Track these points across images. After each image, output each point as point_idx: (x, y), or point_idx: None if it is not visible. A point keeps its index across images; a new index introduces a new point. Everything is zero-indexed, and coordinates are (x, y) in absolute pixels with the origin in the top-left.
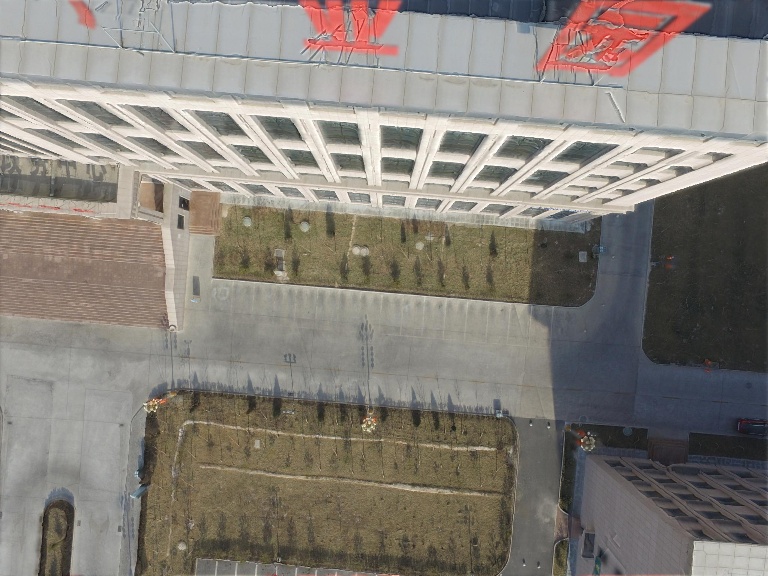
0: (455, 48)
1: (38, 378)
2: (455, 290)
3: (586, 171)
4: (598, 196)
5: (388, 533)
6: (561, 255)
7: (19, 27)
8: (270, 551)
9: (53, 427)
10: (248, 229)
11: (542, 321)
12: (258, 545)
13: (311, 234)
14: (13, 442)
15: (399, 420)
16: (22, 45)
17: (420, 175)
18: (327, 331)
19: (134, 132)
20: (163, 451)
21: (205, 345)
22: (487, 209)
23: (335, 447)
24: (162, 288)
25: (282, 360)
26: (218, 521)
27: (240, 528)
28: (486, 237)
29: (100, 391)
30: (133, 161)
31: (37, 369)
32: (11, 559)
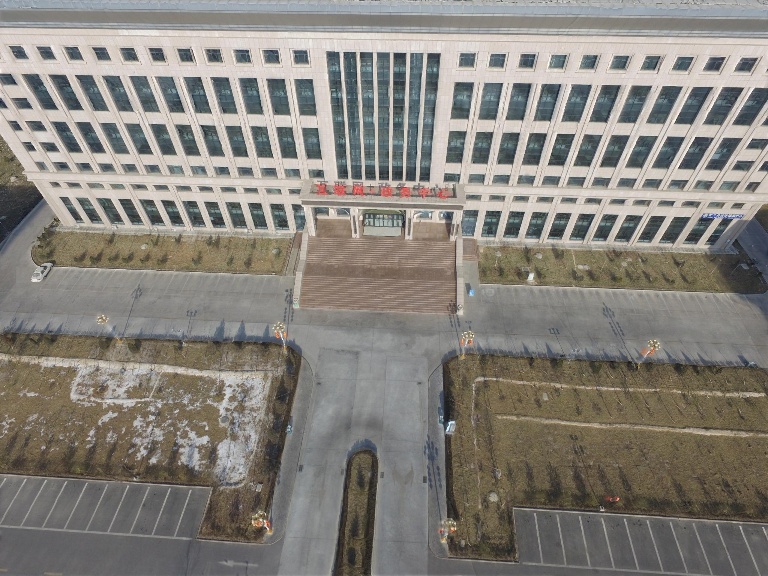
0: (730, 1)
1: (346, 349)
2: (663, 287)
3: (752, 131)
4: (753, 176)
5: (705, 479)
6: (728, 266)
7: (587, 0)
8: (589, 500)
9: (358, 386)
10: (500, 258)
11: (741, 303)
12: (573, 495)
13: (545, 260)
14: (320, 399)
15: (665, 373)
16: (590, 2)
17: (651, 161)
18: (577, 313)
19: (514, 125)
20: (460, 403)
21: (483, 324)
22: (663, 240)
23: (617, 397)
24: (451, 281)
25: (548, 332)
26: (524, 471)
27: (549, 478)
28: (669, 258)
29: (399, 357)
30: (468, 178)
31: (346, 343)
32: (307, 517)
